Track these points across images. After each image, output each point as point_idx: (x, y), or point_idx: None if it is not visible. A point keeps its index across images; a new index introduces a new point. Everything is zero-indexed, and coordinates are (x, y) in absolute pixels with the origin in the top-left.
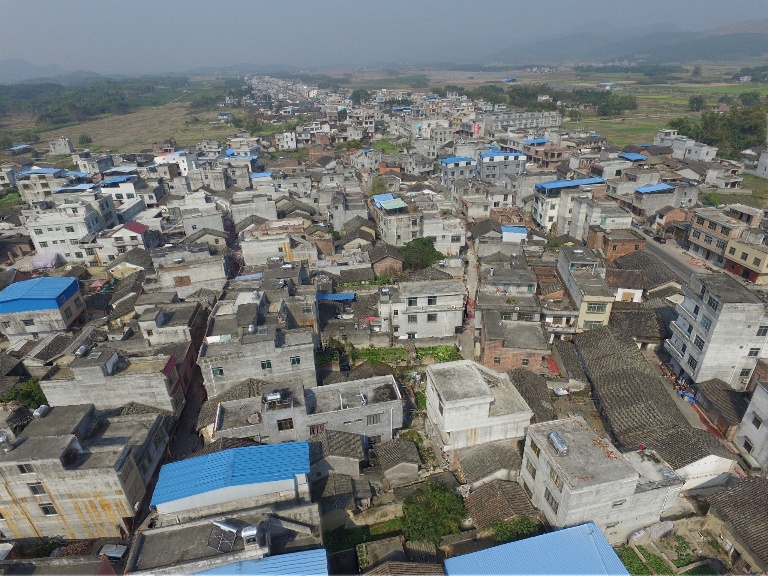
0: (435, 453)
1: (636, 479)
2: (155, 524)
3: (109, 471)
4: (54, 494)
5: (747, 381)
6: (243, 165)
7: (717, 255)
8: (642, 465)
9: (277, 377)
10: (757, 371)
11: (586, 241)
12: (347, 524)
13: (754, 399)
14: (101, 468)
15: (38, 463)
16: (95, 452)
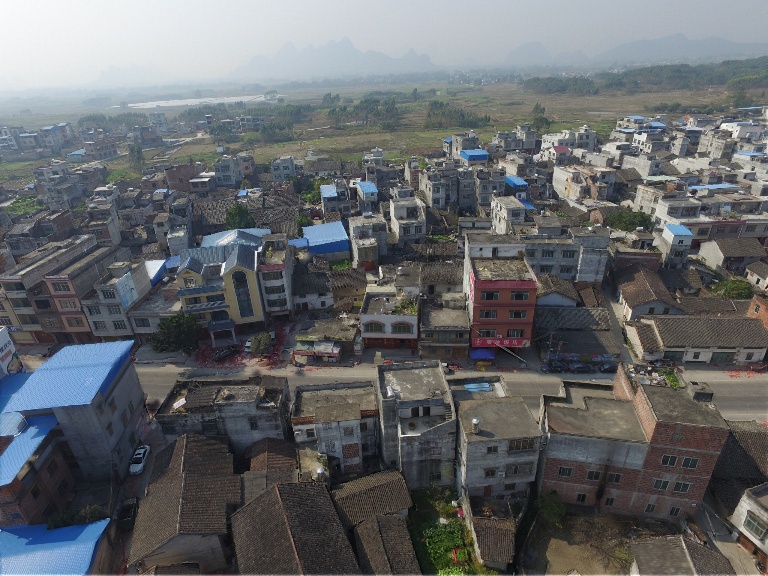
0: None
1: (353, 229)
2: None
3: None
4: None
5: None
6: (761, 143)
7: None
8: None
9: None
10: None
11: None
12: None
13: None
14: None
15: None
16: None
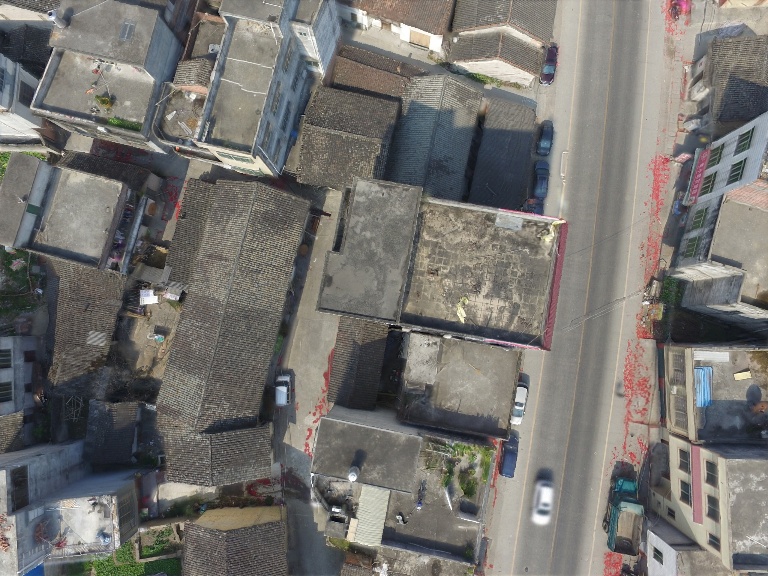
0: None
1: None
2: None
3: None
4: None
5: None
6: None
7: None
8: (85, 518)
9: None
10: None
11: None
12: None
13: None
14: None
15: None
16: None
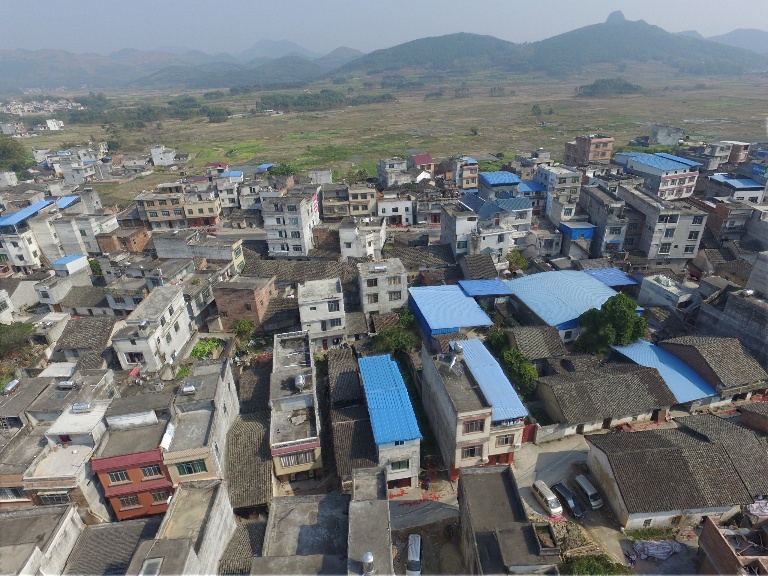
0: None
1: None
2: None
3: None
4: None
5: (314, 243)
6: None
7: (178, 221)
8: None
9: (230, 417)
10: (315, 235)
11: (100, 251)
12: None
13: (341, 237)
14: None
15: None
16: None
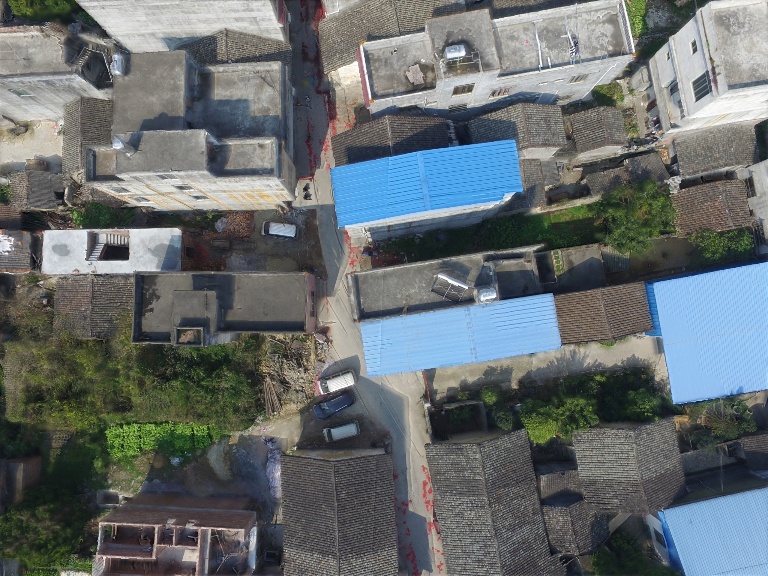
0: (637, 118)
1: None
2: (309, 194)
3: (270, 179)
4: (205, 190)
5: None
6: None
7: None
8: None
9: None
10: None
11: None
12: (529, 213)
13: None
14: (260, 177)
15: (181, 174)
16: (234, 144)
